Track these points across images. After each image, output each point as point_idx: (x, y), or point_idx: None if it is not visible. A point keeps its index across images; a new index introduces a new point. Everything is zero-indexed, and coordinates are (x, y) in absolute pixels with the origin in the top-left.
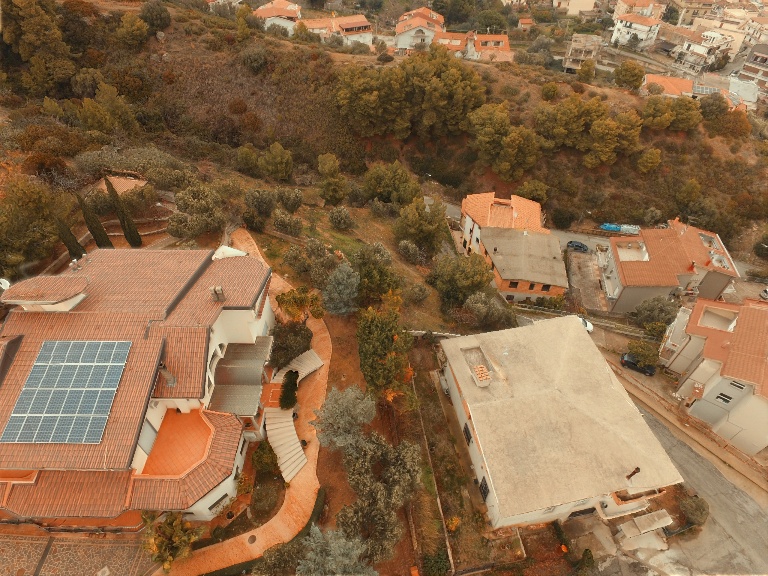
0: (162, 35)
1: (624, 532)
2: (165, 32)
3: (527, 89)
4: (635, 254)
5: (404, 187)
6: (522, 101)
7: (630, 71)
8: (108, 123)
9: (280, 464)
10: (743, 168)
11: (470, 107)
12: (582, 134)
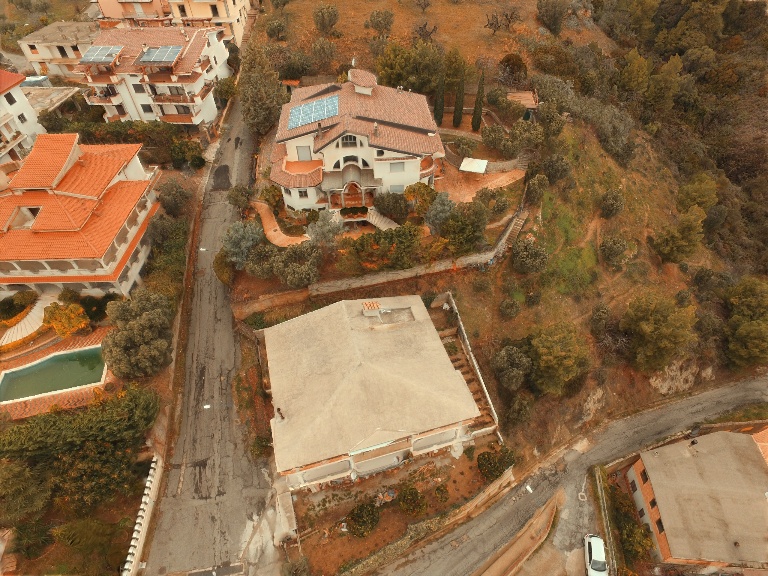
0: None
1: (281, 482)
2: None
3: None
4: None
5: (760, 324)
6: None
7: None
8: (635, 83)
9: None
10: None
11: None
12: None
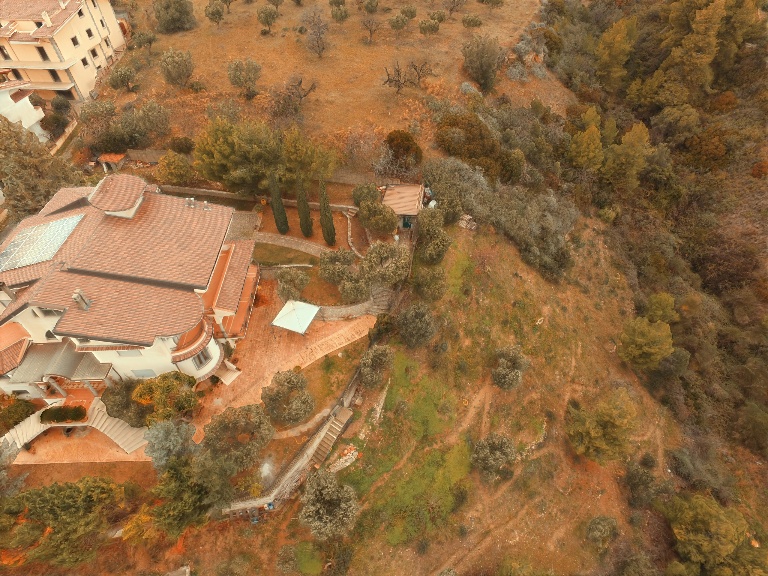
0: None
1: None
2: None
3: None
4: None
5: None
6: None
7: None
8: (584, 159)
9: (16, 428)
10: None
11: None
12: None
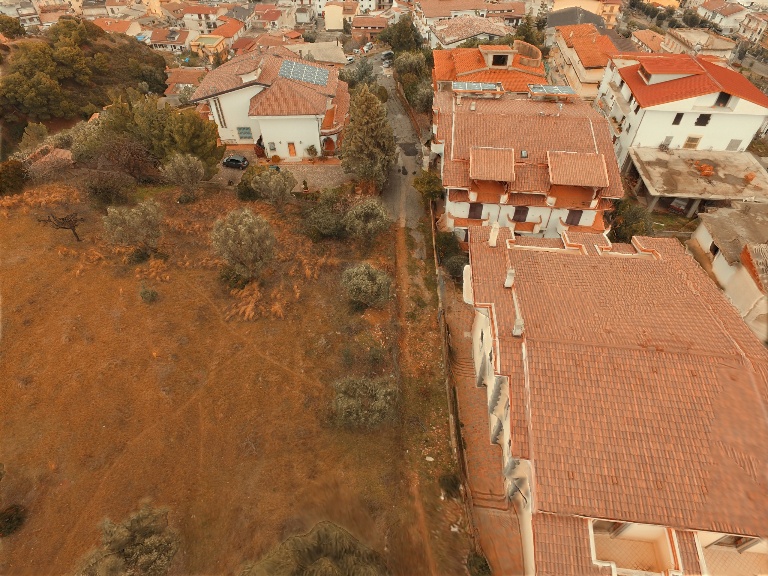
0: None
1: None
2: None
3: None
4: None
5: None
6: None
7: (11, 22)
8: None
9: None
10: (128, 47)
11: None
12: None
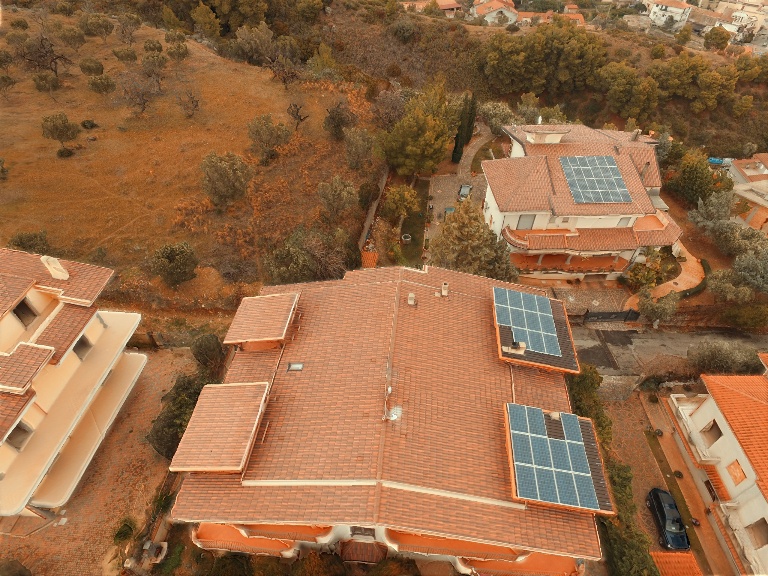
0: (330, 10)
1: None
2: (330, 7)
3: (638, 51)
4: (754, 172)
5: None
6: (635, 60)
7: (720, 35)
8: None
9: None
10: None
11: (595, 66)
12: (689, 85)
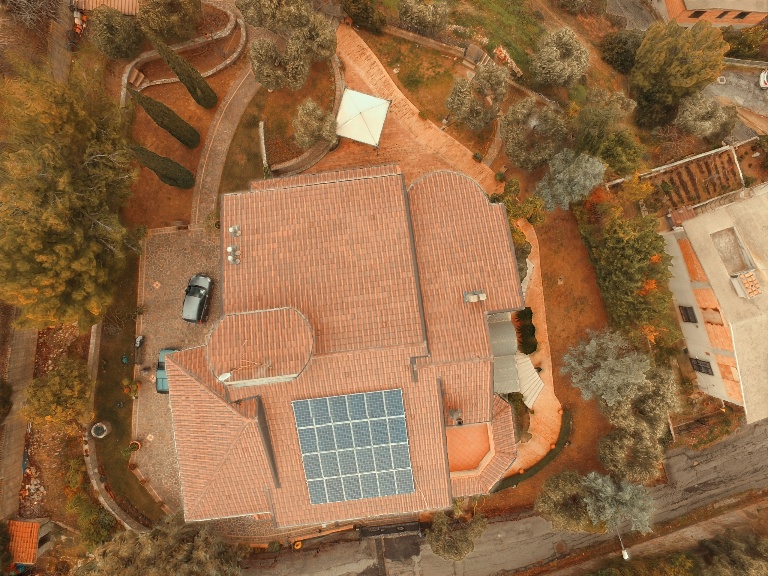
0: None
1: None
2: None
3: None
4: None
5: None
6: None
7: None
8: None
9: None
10: None
11: None
12: None
